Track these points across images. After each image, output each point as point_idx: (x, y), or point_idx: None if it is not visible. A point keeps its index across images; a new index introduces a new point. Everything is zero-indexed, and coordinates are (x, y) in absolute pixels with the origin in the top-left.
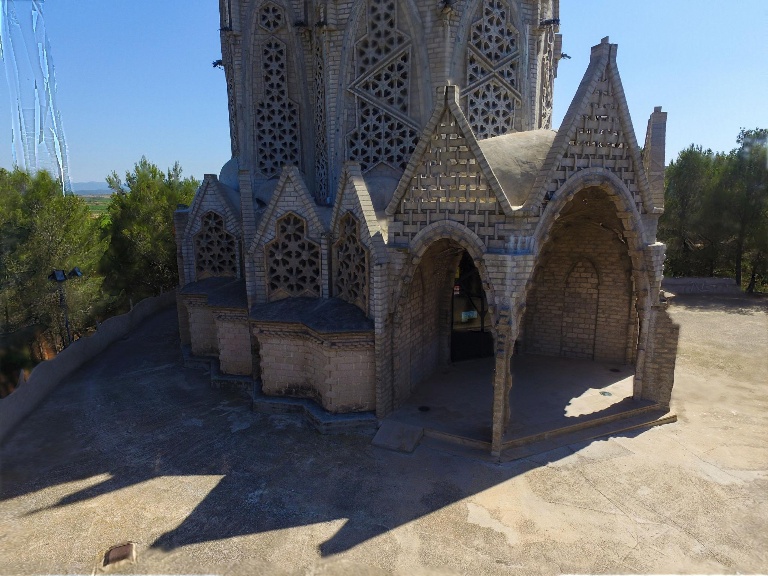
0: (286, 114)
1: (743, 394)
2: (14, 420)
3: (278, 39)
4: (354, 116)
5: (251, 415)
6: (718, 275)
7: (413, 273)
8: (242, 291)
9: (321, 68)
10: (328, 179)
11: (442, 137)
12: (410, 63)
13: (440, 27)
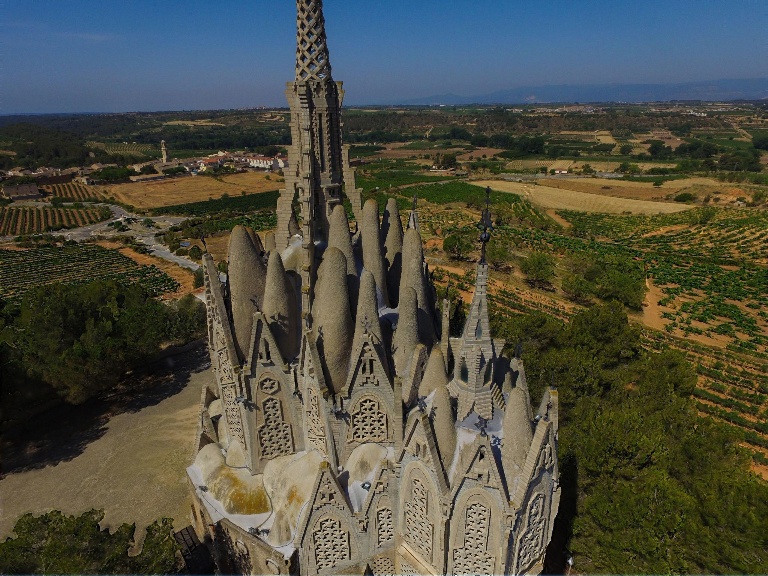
0: None
1: None
2: None
3: None
4: None
5: None
6: None
7: None
8: None
9: None
10: None
11: None
12: None
13: None
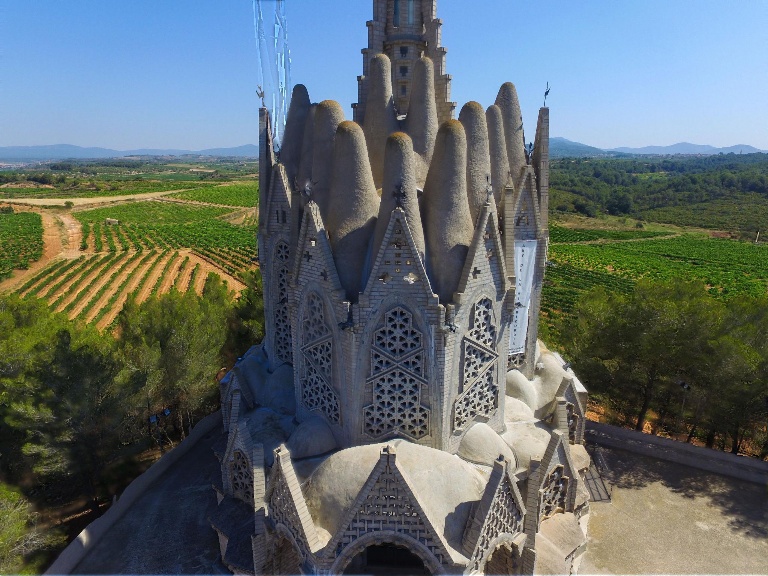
0: None
1: None
2: (105, 529)
3: None
4: None
5: (209, 575)
6: None
7: (280, 543)
8: None
9: None
10: None
11: None
12: (331, 350)
13: (348, 333)
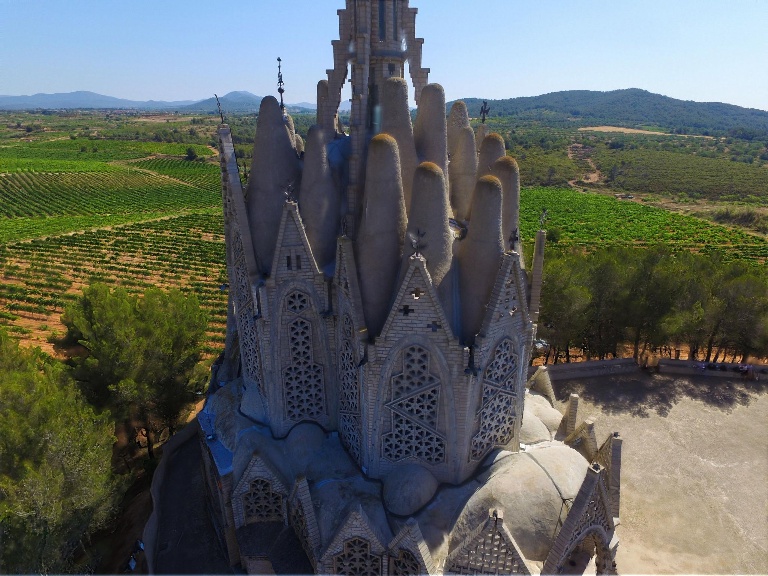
0: (312, 375)
1: (651, 570)
2: None
3: (304, 319)
4: (389, 422)
5: None
6: (621, 342)
7: None
8: (304, 562)
9: None
10: (361, 450)
11: (489, 535)
12: (439, 397)
13: (464, 377)
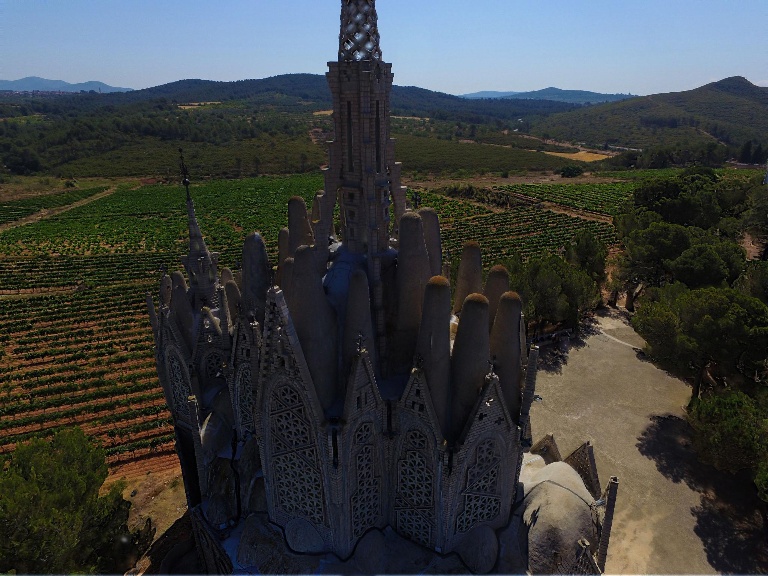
0: None
1: None
2: None
3: (369, 445)
4: (462, 504)
5: None
6: None
7: None
8: None
9: (430, 476)
10: (432, 535)
11: None
12: None
13: (516, 448)
